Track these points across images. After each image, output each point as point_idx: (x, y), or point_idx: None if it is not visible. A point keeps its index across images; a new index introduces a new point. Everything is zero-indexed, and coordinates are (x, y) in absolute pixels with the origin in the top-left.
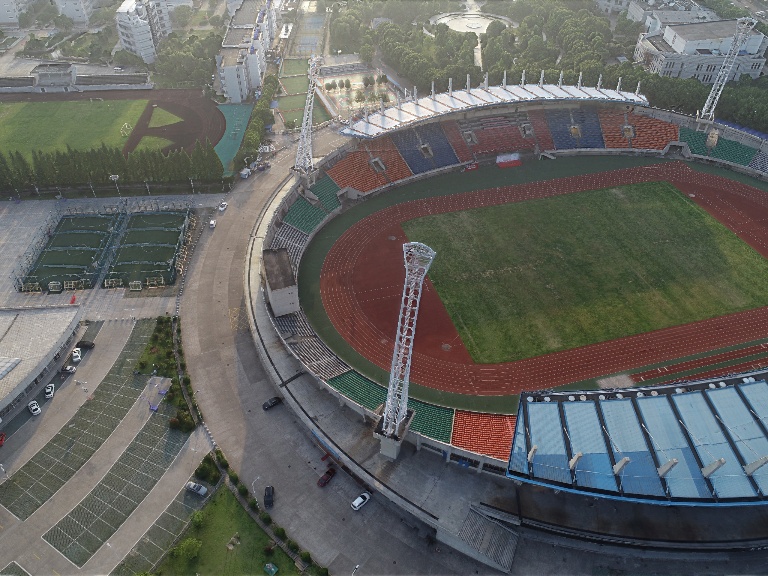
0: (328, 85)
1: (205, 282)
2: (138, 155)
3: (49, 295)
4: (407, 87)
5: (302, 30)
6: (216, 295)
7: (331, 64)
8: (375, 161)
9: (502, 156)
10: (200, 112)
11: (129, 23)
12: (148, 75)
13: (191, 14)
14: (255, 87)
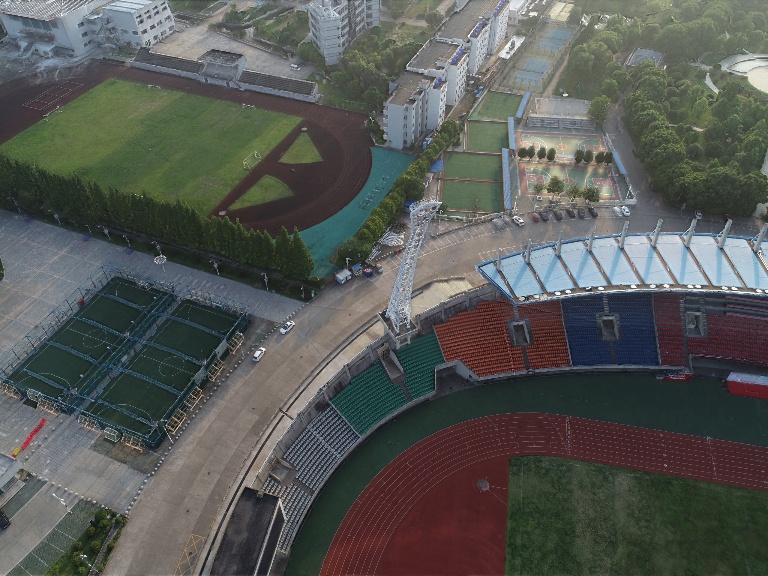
0: (522, 151)
1: (192, 463)
2: (216, 223)
3: (23, 405)
4: (638, 177)
5: (534, 48)
6: (191, 496)
7: (544, 114)
8: (519, 324)
9: (741, 374)
10: (347, 152)
11: (319, 14)
12: (316, 85)
13: (409, 4)
14: (431, 128)
